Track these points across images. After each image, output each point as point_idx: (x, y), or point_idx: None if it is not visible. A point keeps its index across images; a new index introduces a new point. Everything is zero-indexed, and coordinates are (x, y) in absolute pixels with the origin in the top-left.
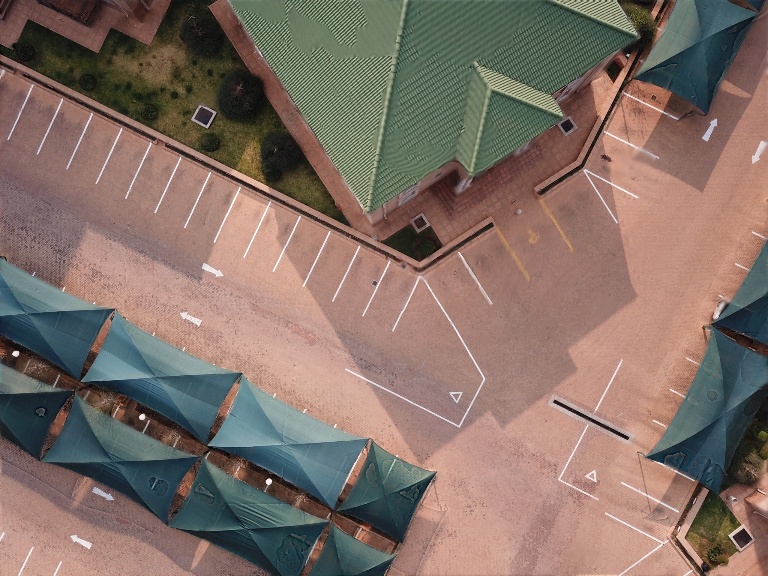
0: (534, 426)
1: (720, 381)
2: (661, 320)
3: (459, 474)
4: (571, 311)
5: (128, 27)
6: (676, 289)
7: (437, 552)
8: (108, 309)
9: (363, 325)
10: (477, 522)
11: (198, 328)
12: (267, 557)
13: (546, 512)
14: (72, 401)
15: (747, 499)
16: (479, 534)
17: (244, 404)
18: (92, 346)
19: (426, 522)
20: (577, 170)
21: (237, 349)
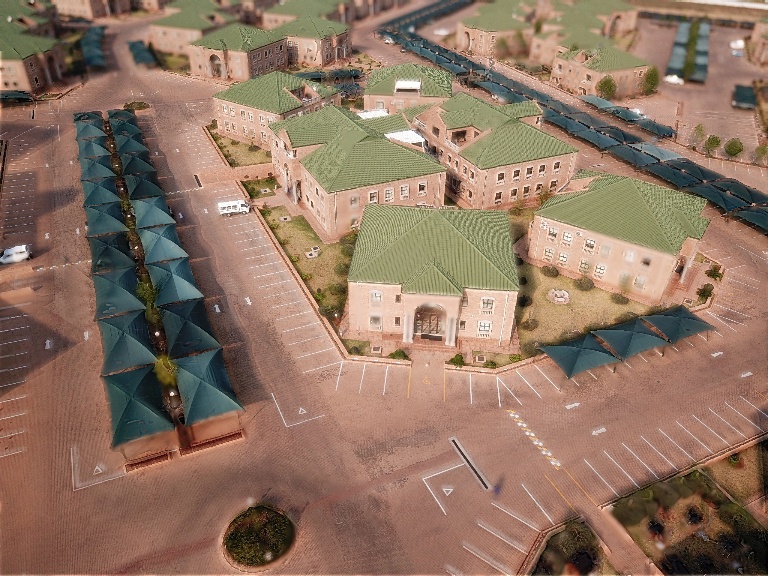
0: None
1: None
2: None
3: None
4: None
5: None
6: None
7: None
8: None
9: None
10: None
11: None
12: (130, 118)
13: None
14: None
15: None
16: None
17: (85, 135)
18: None
19: None
20: None
21: None
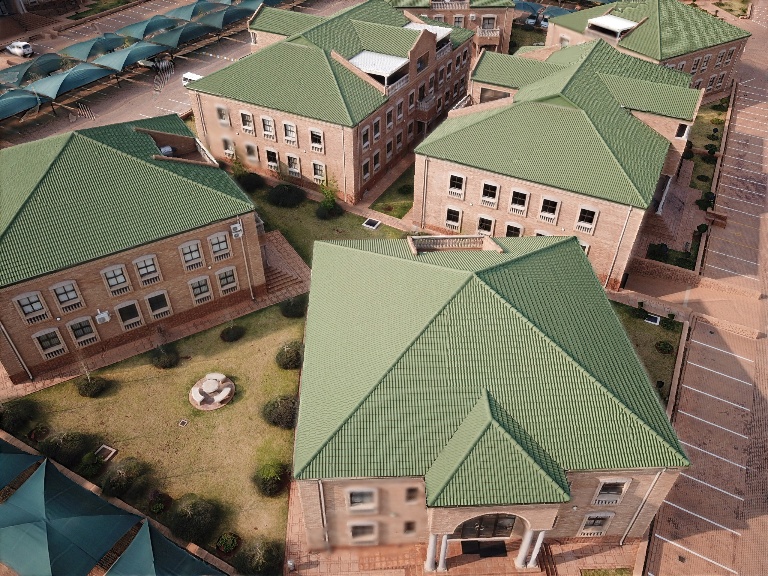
0: None
1: None
2: None
3: None
4: None
5: (87, 4)
6: None
7: None
8: None
9: None
10: None
11: None
12: None
13: None
14: (242, 24)
15: None
16: None
17: None
18: None
19: None
20: None
21: None
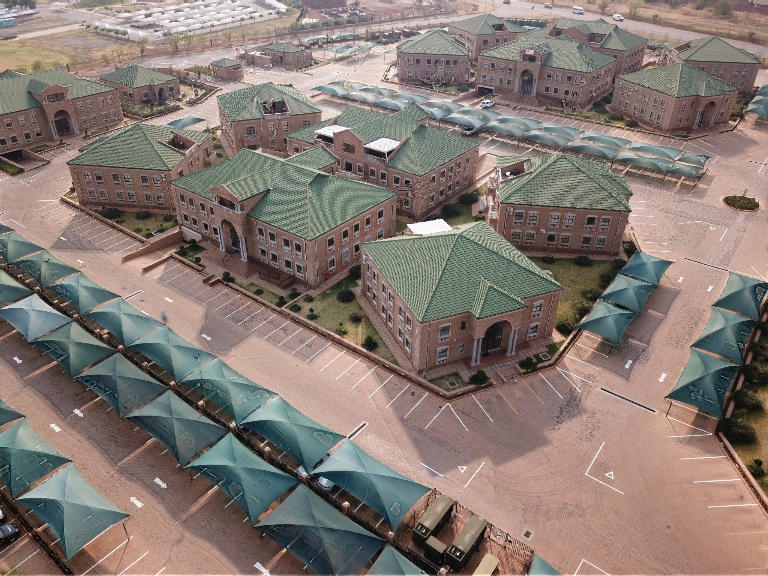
0: None
1: None
2: None
3: None
4: None
5: None
6: None
7: (717, 182)
8: None
9: None
10: None
11: None
12: None
13: None
14: None
15: None
16: None
17: None
18: None
19: None
20: (732, 130)
21: None
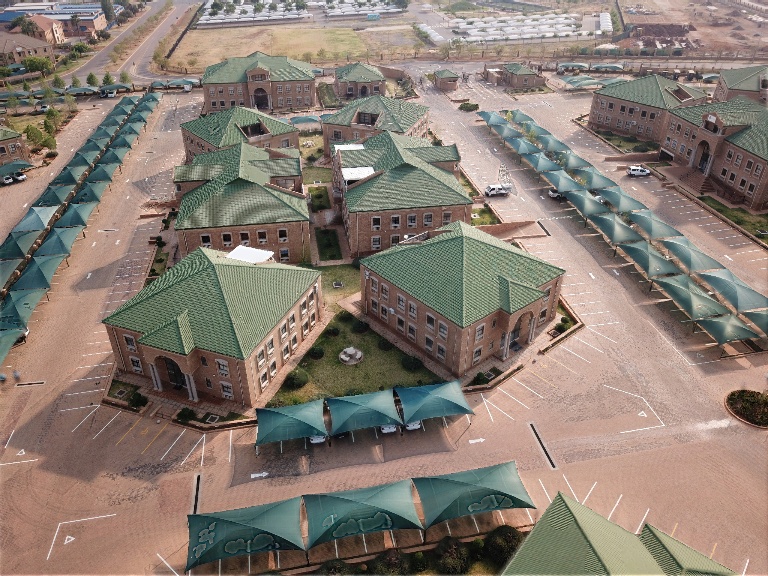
0: None
1: None
2: None
3: None
4: None
5: None
6: None
7: None
8: None
9: None
10: None
11: None
12: (692, 301)
13: None
14: None
15: None
16: None
17: None
18: (665, 237)
19: None
20: None
21: None
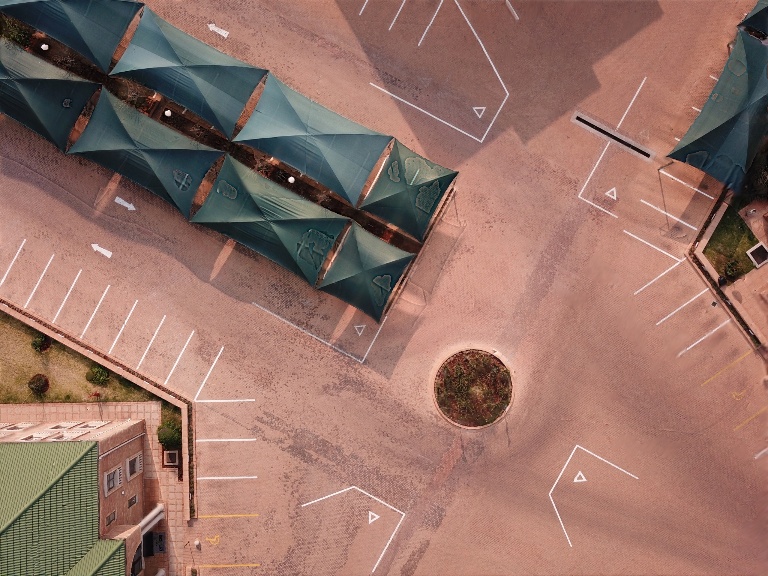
0: (556, 142)
1: (745, 77)
2: (686, 38)
3: (479, 190)
4: (597, 27)
5: None
6: (702, 7)
7: (455, 267)
8: (138, 3)
9: (389, 39)
10: (496, 238)
11: (225, 40)
12: (287, 249)
13: (565, 229)
14: None
15: (766, 214)
16: (497, 250)
17: (270, 99)
18: (121, 41)
19: (445, 237)
20: None
21: (263, 61)
